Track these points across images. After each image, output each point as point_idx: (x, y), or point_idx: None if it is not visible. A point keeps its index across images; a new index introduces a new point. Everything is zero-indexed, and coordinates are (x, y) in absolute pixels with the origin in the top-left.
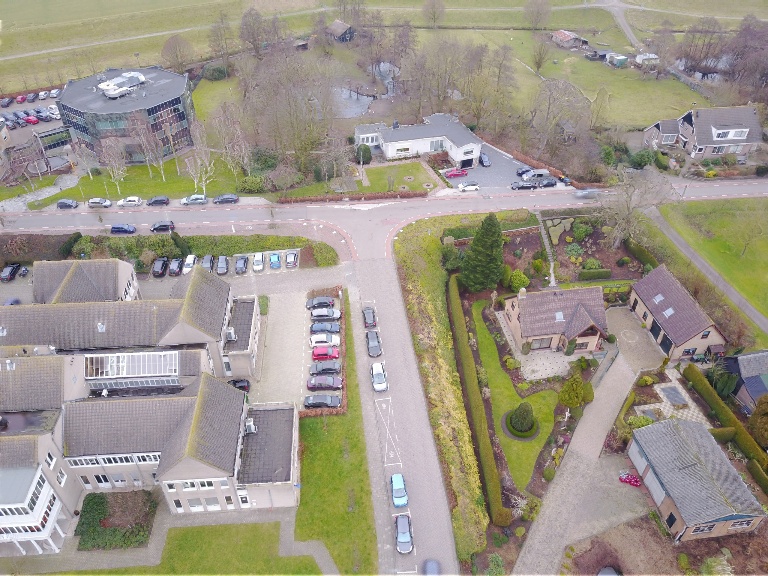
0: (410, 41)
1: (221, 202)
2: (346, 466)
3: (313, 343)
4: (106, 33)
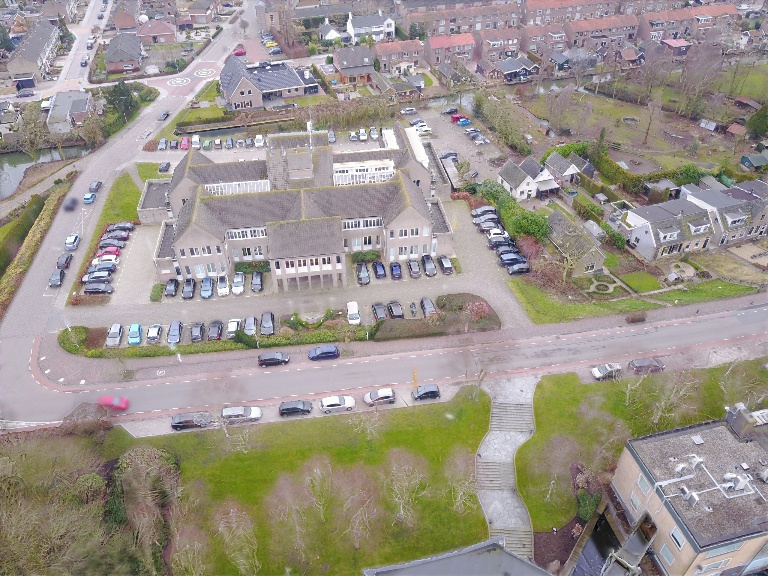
0: None
1: None
2: (117, 209)
3: None
4: None
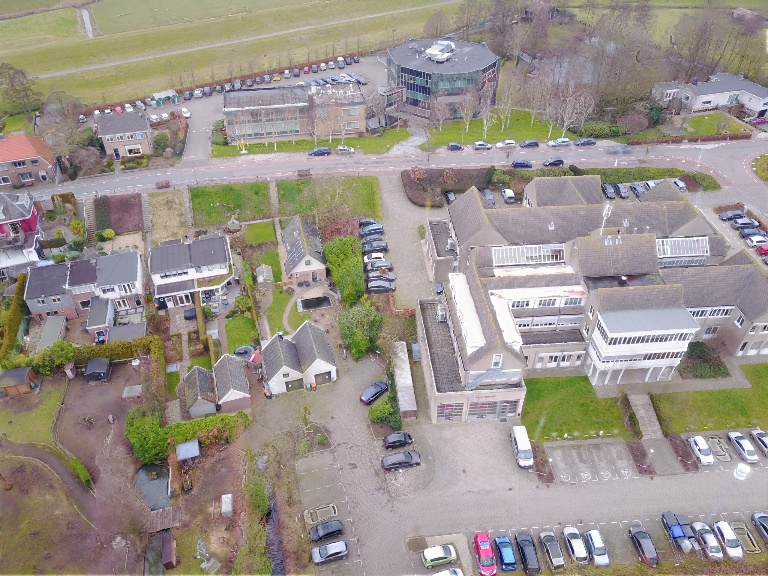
0: (644, 15)
1: (583, 144)
2: None
3: (754, 242)
4: (334, 14)
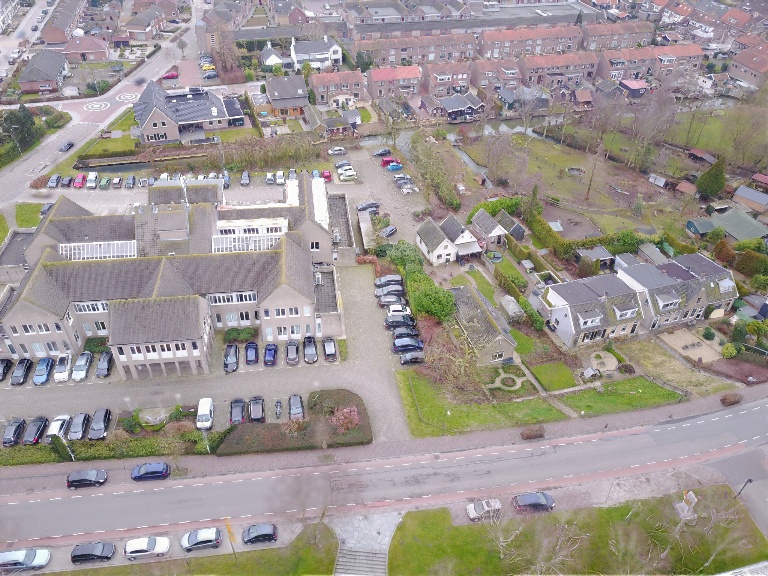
0: None
1: None
2: None
3: None
4: None
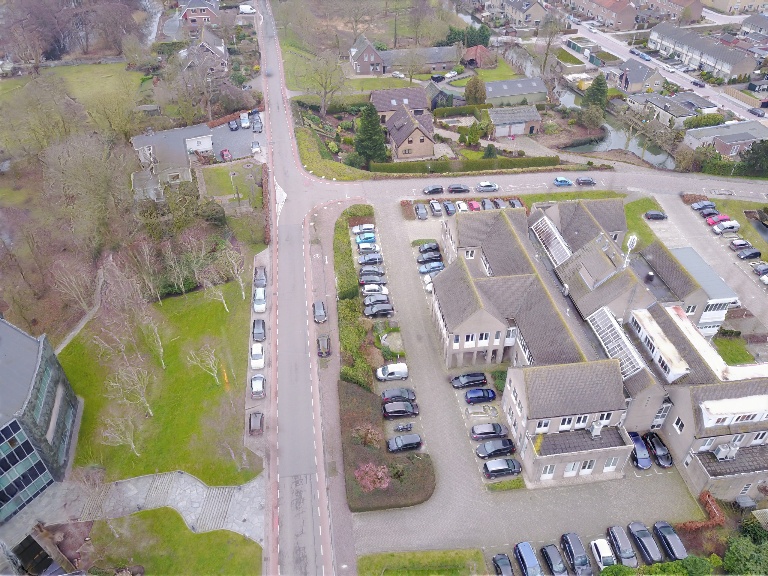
0: None
1: None
2: None
3: None
4: None
